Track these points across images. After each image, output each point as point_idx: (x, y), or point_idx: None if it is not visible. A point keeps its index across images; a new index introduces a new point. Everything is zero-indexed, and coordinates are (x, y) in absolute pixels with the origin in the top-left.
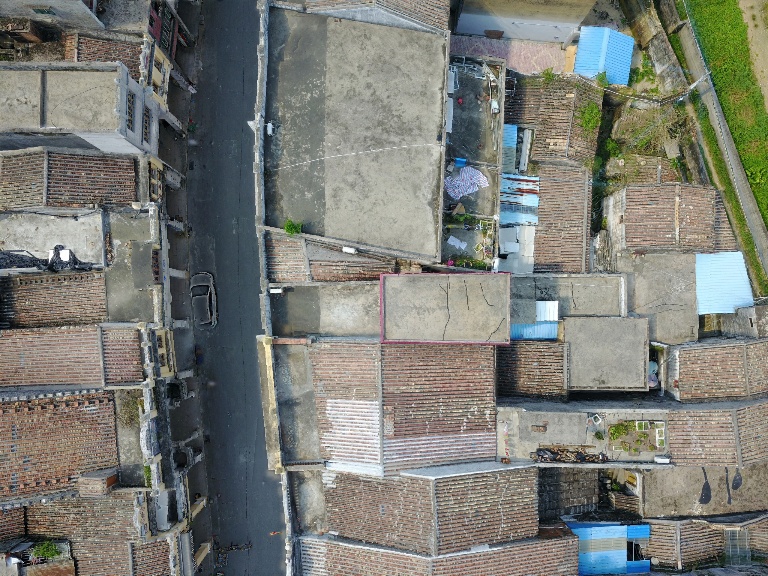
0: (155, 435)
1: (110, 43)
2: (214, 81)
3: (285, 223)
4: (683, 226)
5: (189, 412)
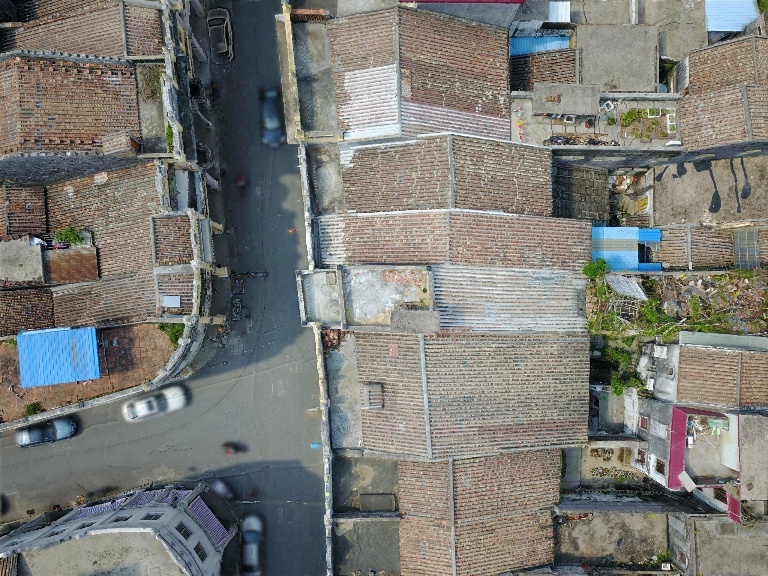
0: (176, 105)
1: None
2: None
3: None
4: None
5: None
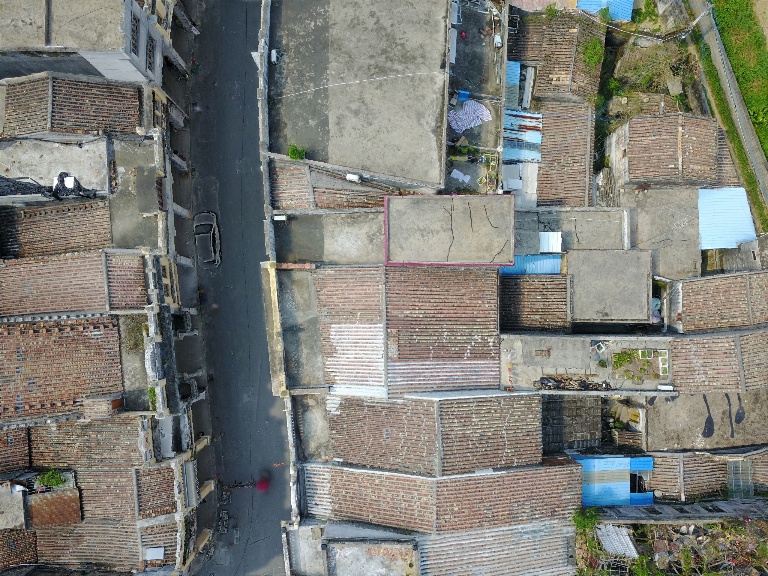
0: (160, 360)
1: None
2: (217, 22)
3: (289, 150)
4: (686, 156)
5: (193, 351)
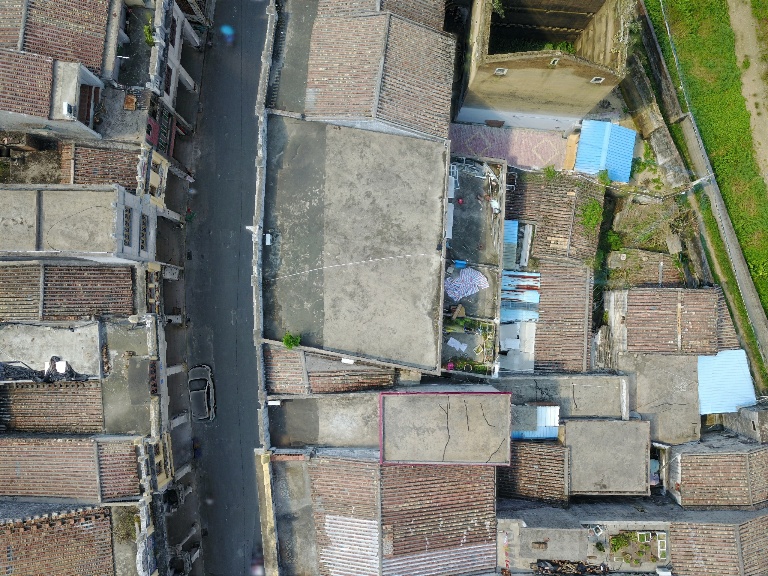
0: (152, 552)
1: (107, 152)
2: (212, 170)
3: (283, 335)
4: (685, 332)
5: (187, 506)
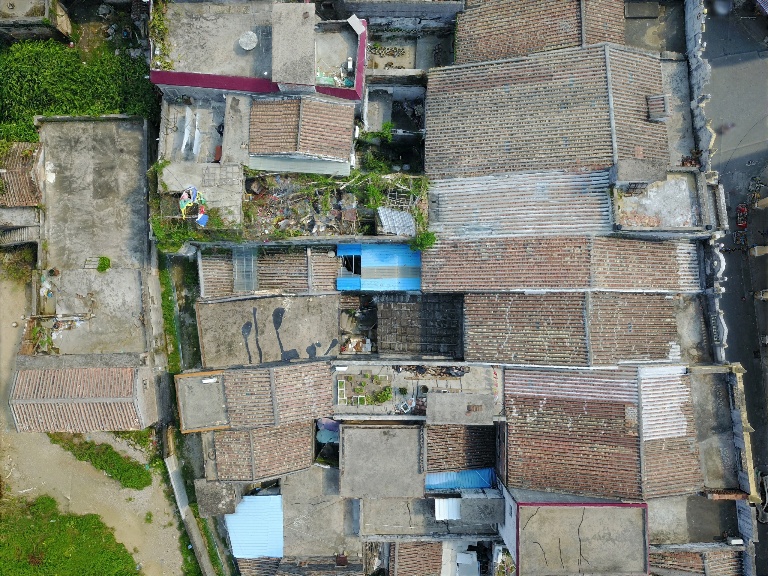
0: None
1: None
2: None
3: None
4: None
5: None
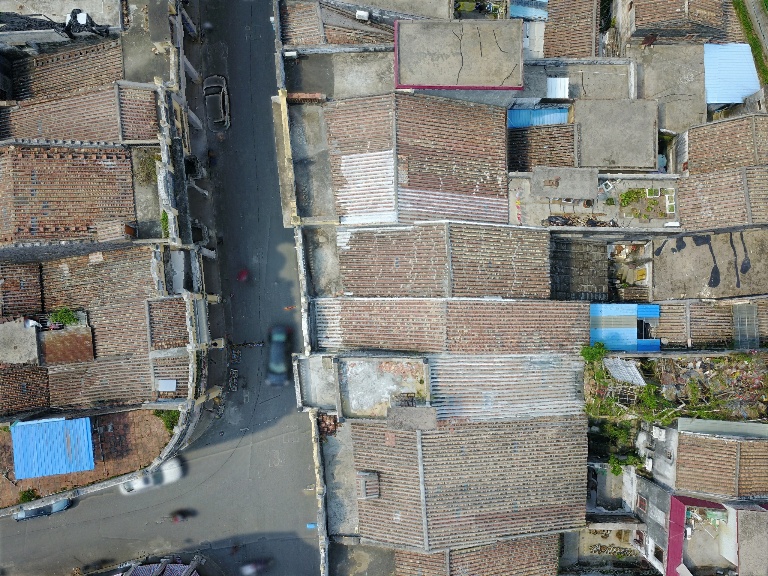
0: (172, 190)
1: None
2: None
3: None
4: (692, 1)
5: (202, 214)
